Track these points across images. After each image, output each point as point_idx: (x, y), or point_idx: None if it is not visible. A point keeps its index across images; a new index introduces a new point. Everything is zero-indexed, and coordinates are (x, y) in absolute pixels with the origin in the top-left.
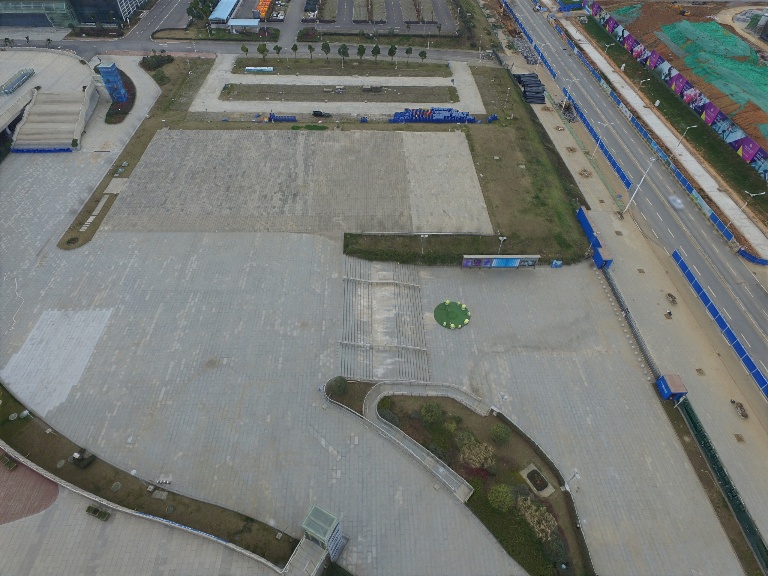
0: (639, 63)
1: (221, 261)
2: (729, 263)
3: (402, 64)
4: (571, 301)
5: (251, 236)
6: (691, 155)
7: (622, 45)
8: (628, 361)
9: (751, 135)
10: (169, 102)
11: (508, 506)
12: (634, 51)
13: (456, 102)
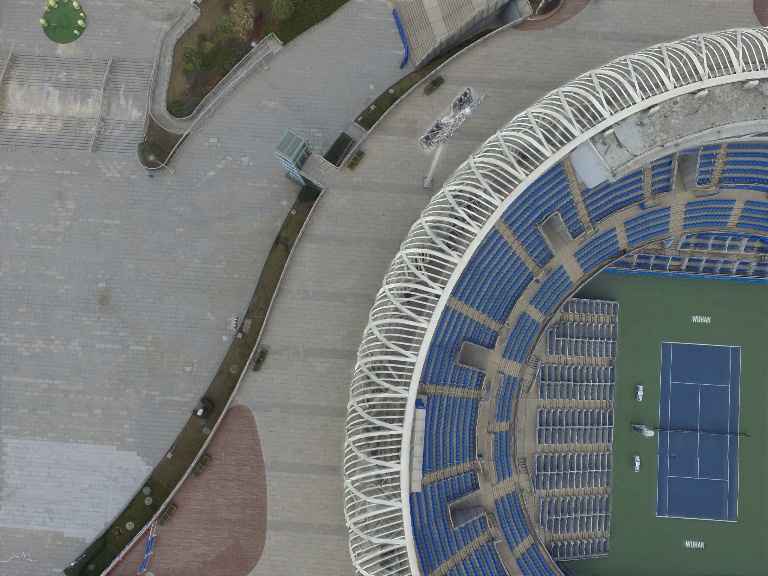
0: None
1: None
2: None
3: None
4: None
5: None
6: None
7: None
8: None
9: None
10: None
11: (290, 1)
12: None
13: None
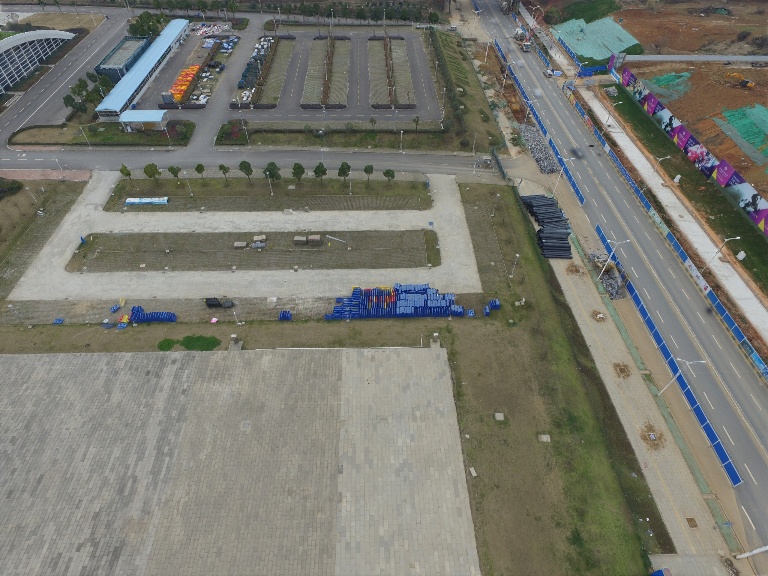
0: (699, 171)
1: None
2: None
3: (360, 185)
4: None
5: None
6: None
7: (670, 137)
8: None
9: None
10: None
11: None
12: (690, 151)
13: (436, 266)
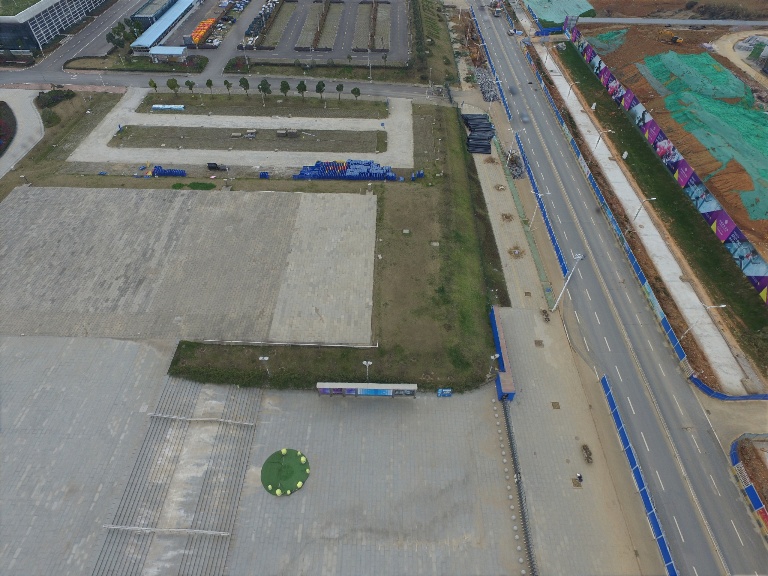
0: (614, 101)
1: (8, 382)
2: (676, 395)
3: (333, 102)
4: (450, 453)
5: (62, 343)
6: (655, 227)
7: (598, 78)
8: (505, 562)
9: (730, 204)
10: (48, 149)
11: None
12: (609, 87)
13: (382, 152)
